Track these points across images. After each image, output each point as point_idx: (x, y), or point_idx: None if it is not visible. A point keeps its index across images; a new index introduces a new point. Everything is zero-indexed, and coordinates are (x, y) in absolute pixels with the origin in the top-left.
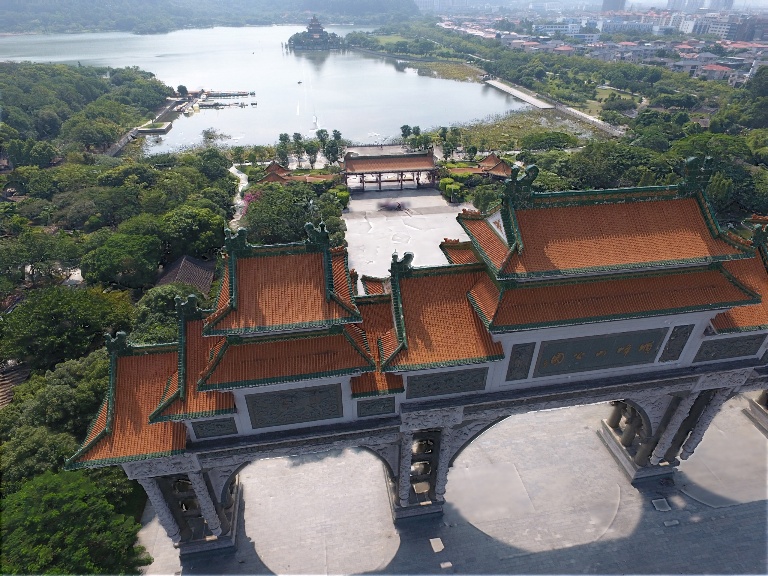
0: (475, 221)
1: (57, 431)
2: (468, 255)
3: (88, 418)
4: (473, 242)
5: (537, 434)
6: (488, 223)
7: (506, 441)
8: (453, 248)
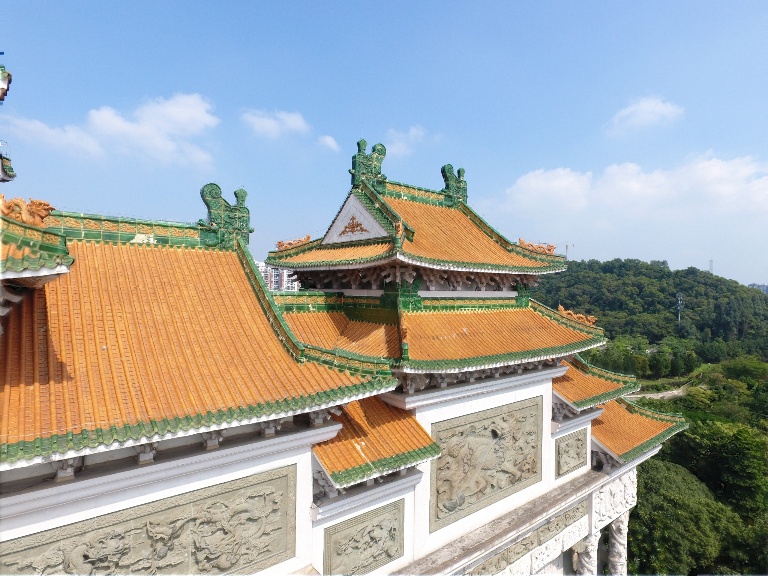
0: None
1: (732, 548)
2: None
3: (745, 570)
4: None
5: None
6: None
7: None
8: None
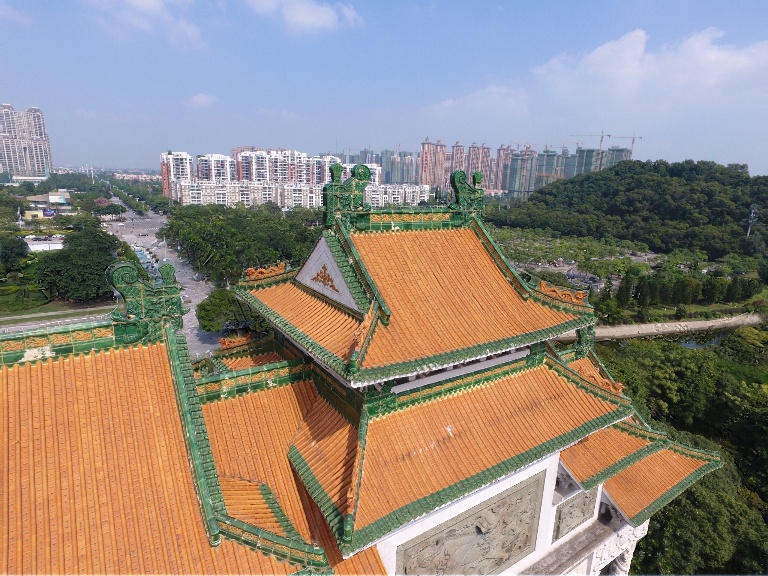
0: None
1: (748, 554)
2: None
3: None
4: None
5: None
6: None
7: None
8: None
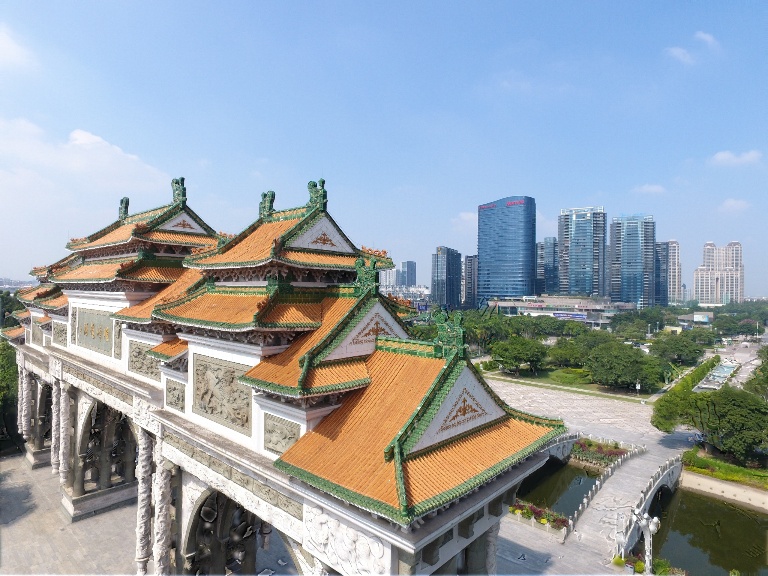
0: (147, 234)
1: None
2: (151, 270)
3: None
4: (181, 243)
5: (78, 555)
6: (164, 230)
7: (95, 572)
8: (130, 272)
